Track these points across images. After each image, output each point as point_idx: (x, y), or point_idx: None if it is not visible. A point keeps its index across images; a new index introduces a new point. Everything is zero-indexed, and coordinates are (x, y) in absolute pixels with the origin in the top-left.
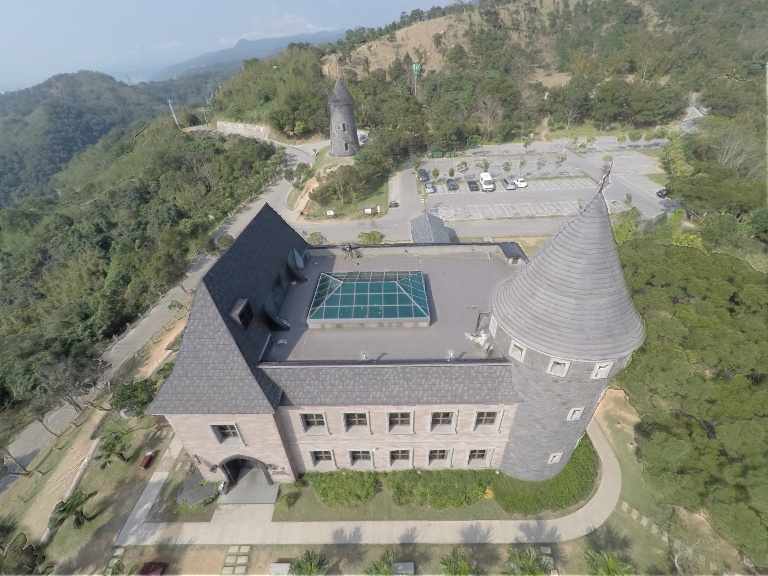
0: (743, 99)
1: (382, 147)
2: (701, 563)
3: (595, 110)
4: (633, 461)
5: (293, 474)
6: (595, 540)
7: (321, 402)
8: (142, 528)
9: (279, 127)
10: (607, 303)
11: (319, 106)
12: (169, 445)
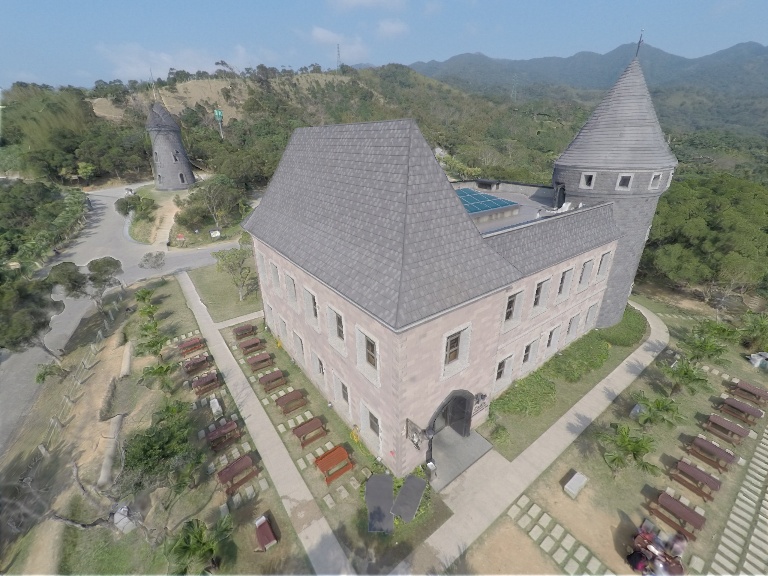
0: (466, 139)
1: (236, 172)
2: (713, 319)
3: None
4: (633, 296)
5: (489, 403)
6: (675, 335)
7: (529, 270)
8: None
9: (49, 170)
10: None
11: (110, 145)
12: (279, 495)
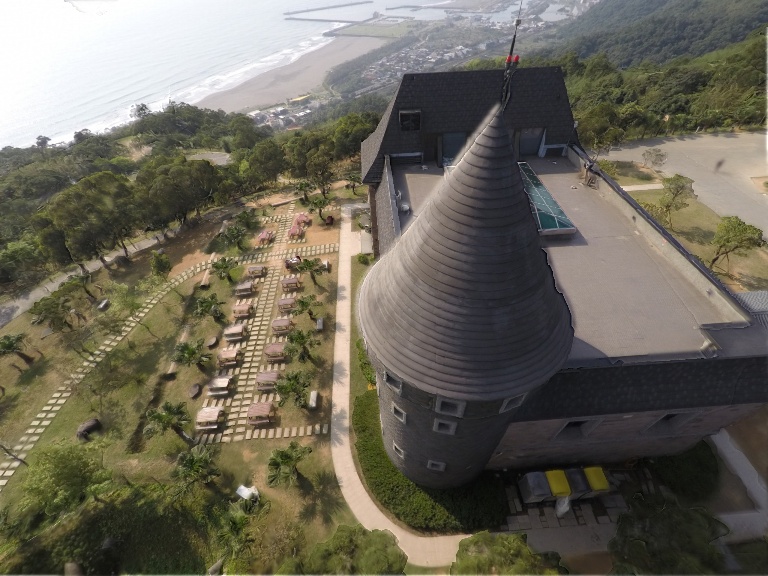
0: None
1: None
2: None
3: None
4: None
5: (374, 251)
6: (331, 483)
7: None
8: (349, 209)
9: None
10: (400, 272)
11: None
12: None
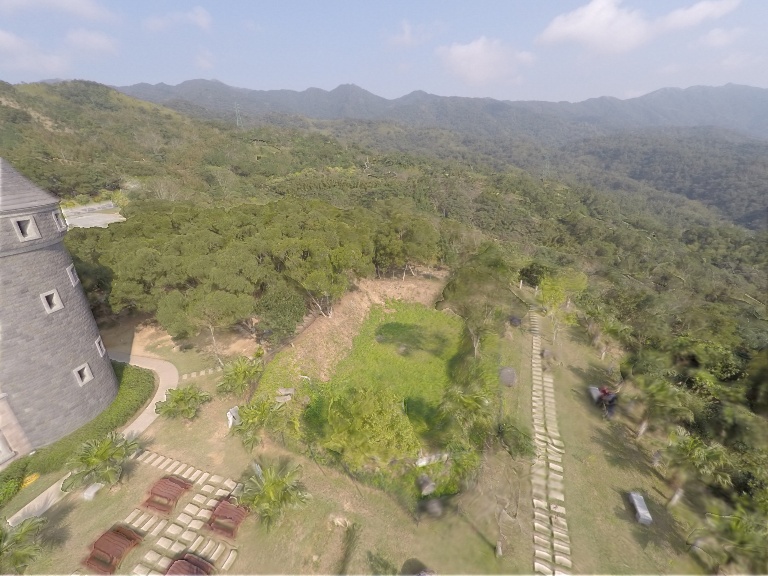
0: (155, 168)
1: None
2: None
3: None
4: (180, 354)
5: None
6: None
7: None
8: None
9: None
10: None
11: None
12: None
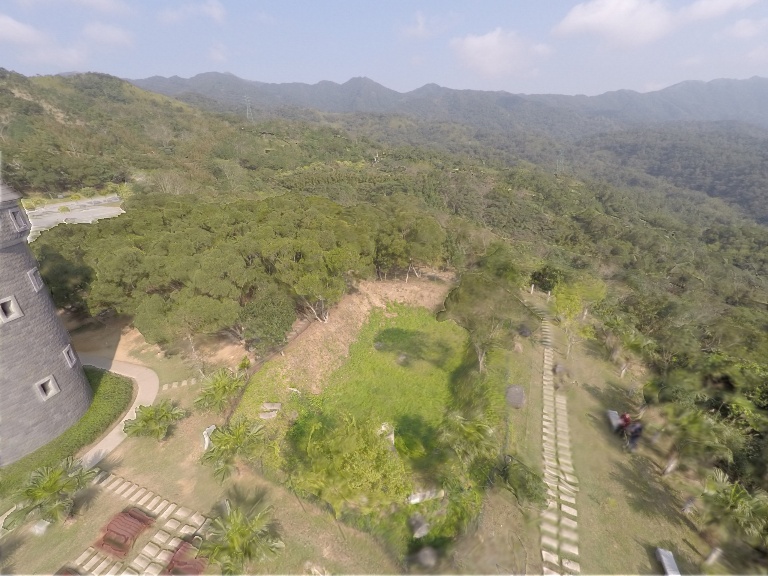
0: (162, 161)
1: None
2: None
3: (29, 179)
4: (164, 361)
5: None
6: None
7: None
8: None
9: None
10: None
11: None
12: None
